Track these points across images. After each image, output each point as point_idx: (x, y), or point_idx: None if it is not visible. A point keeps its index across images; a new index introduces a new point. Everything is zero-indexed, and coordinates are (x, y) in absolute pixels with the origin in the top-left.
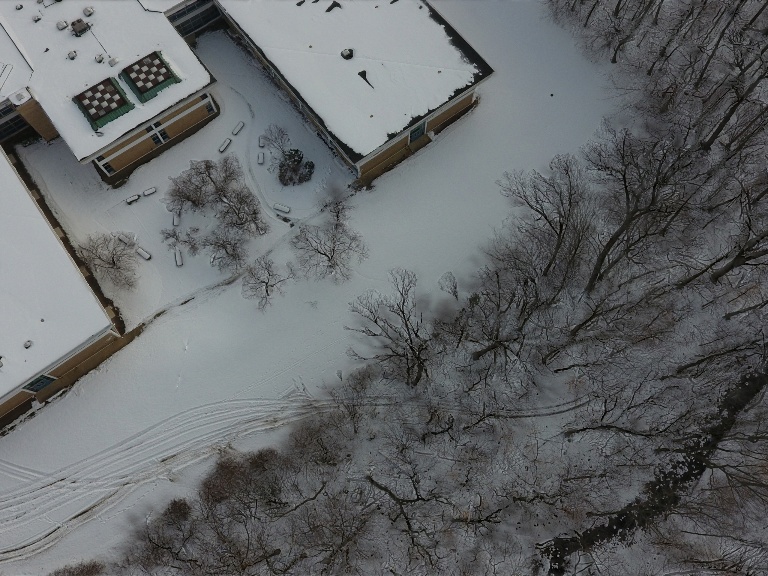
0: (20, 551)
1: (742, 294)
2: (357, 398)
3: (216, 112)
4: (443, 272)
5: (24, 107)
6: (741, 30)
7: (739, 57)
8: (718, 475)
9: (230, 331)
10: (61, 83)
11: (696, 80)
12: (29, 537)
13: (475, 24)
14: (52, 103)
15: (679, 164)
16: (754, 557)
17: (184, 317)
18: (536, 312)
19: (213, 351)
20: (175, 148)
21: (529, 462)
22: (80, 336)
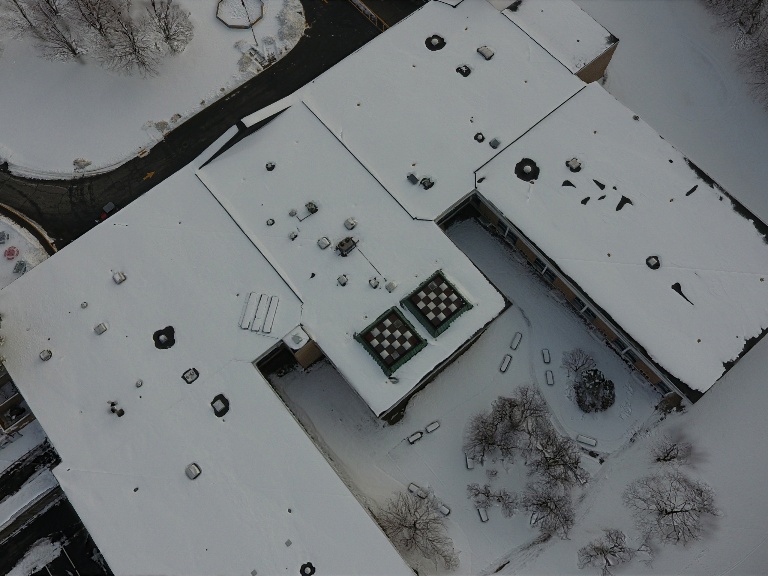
0: None
1: None
2: None
3: None
4: None
5: (301, 350)
6: None
7: None
8: None
9: None
10: (337, 317)
11: None
12: None
13: (750, 195)
14: (332, 343)
15: None
16: None
17: None
18: None
19: None
20: (450, 369)
21: None
22: None
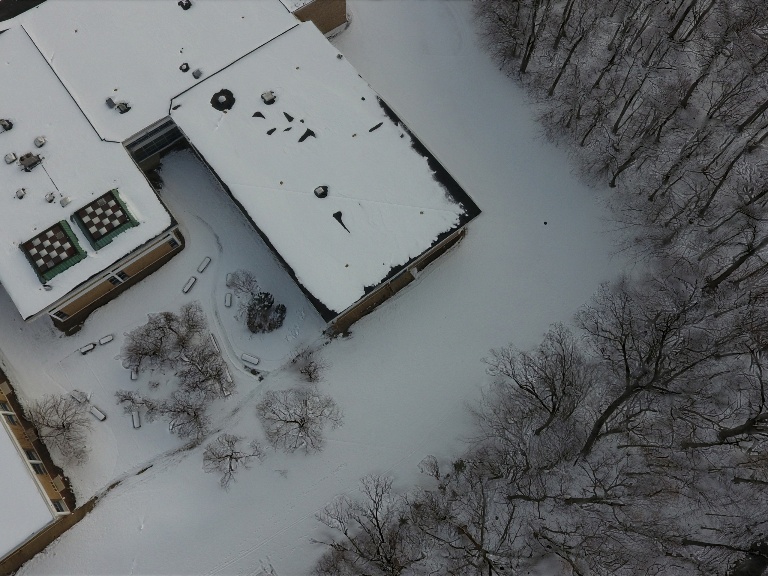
0: None
1: (753, 462)
2: None
3: (180, 245)
4: (426, 432)
5: None
6: (751, 163)
7: (748, 182)
8: None
9: (191, 506)
10: (7, 227)
11: (701, 207)
12: None
13: (463, 141)
14: None
15: None
16: None
17: (141, 489)
18: (527, 480)
19: (171, 531)
20: (135, 288)
21: None
22: (19, 534)
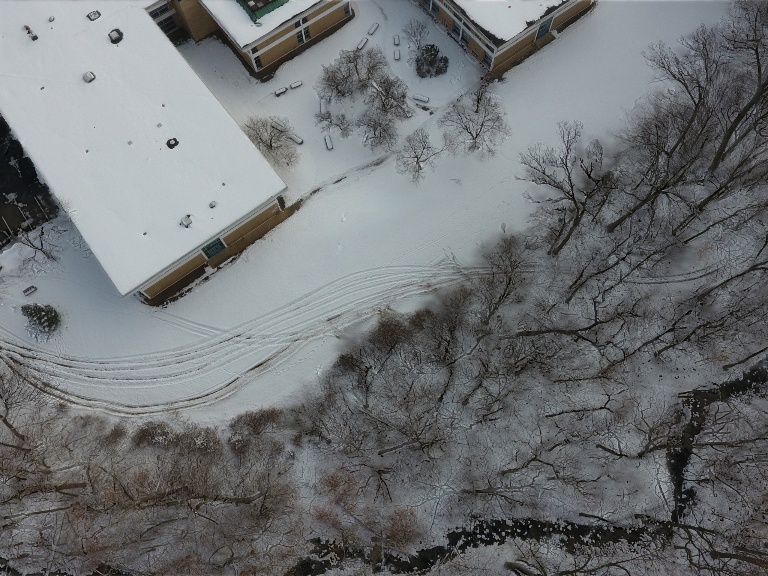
0: (204, 398)
1: None
2: None
3: (351, 15)
4: None
5: (186, 2)
6: None
7: None
8: None
9: (383, 205)
10: None
11: None
12: (211, 386)
13: None
14: None
15: None
16: None
17: (339, 193)
18: None
19: (369, 222)
20: (316, 47)
21: (666, 322)
22: (260, 197)
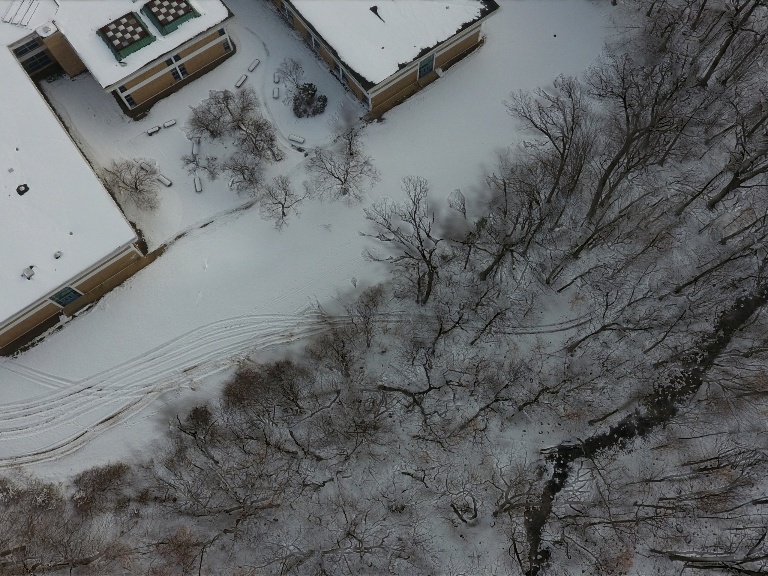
0: (50, 453)
1: (737, 217)
2: (369, 315)
3: (232, 50)
4: None
5: (50, 39)
6: None
7: None
8: (714, 388)
9: (248, 251)
10: (85, 17)
11: (693, 21)
12: (58, 440)
13: None
14: (77, 36)
15: (677, 98)
16: (748, 459)
17: (204, 239)
18: (540, 235)
19: (232, 269)
20: (193, 84)
21: (534, 375)
22: (107, 247)
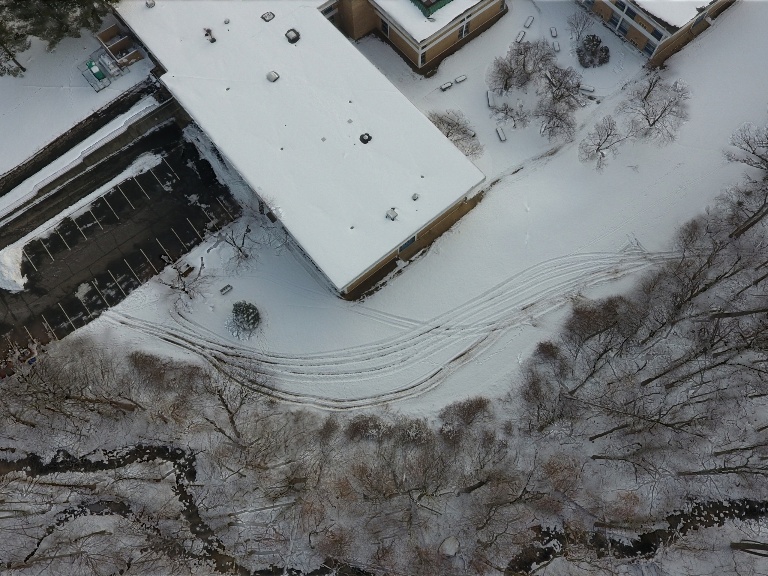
0: (410, 390)
1: None
2: None
3: (505, 9)
4: None
5: (357, 0)
6: None
7: None
8: None
9: (565, 194)
10: None
11: None
12: (417, 378)
13: None
14: None
15: None
16: None
17: (518, 184)
18: None
19: (554, 211)
20: (474, 41)
21: None
22: (461, 188)
